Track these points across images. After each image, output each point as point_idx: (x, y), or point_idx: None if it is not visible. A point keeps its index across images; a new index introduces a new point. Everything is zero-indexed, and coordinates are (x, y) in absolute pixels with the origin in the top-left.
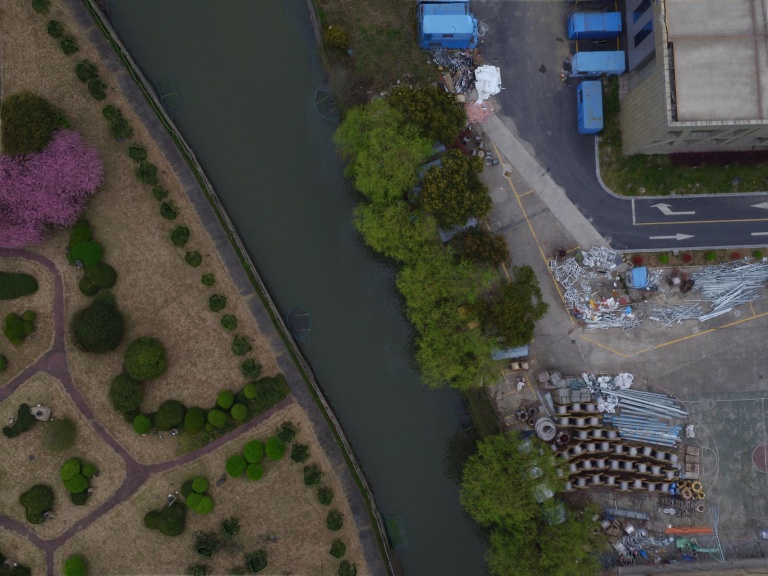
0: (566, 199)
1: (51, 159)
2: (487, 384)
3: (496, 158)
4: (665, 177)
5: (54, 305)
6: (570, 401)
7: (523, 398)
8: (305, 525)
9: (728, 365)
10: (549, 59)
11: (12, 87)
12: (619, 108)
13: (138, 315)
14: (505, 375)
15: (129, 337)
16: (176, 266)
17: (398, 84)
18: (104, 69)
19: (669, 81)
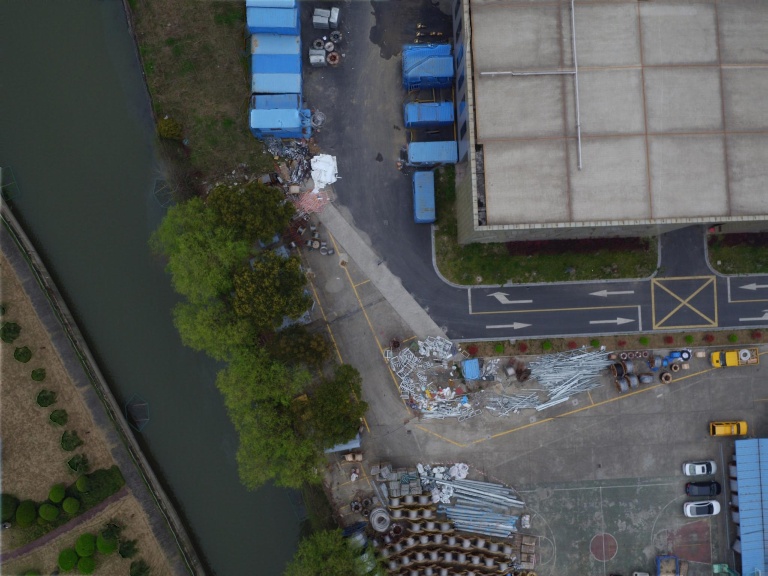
0: (402, 289)
1: None
2: (322, 475)
3: (332, 248)
4: (502, 266)
5: None
6: (400, 494)
7: (358, 488)
8: None
9: (566, 454)
10: (386, 147)
11: None
12: (455, 197)
13: None
14: (340, 465)
15: None
16: (11, 359)
17: (233, 174)
18: None
19: (476, 186)
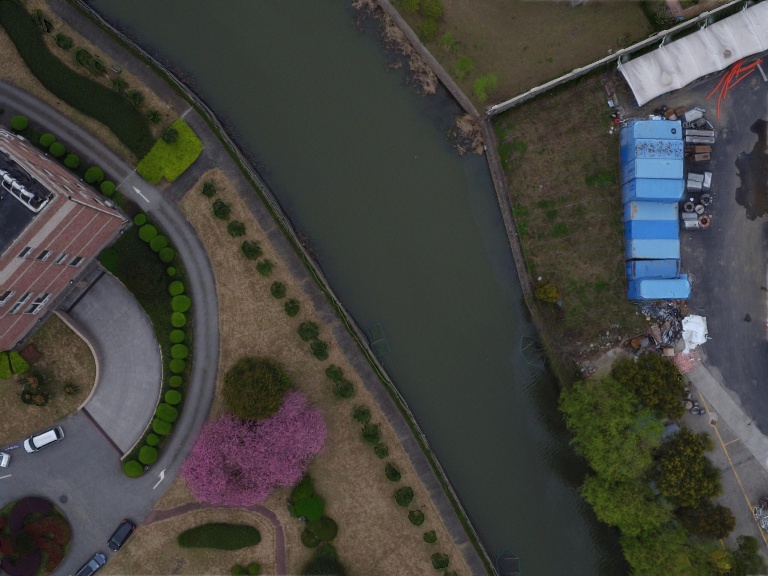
0: None
1: (282, 426)
2: None
3: (703, 407)
4: None
5: (276, 556)
6: None
7: None
8: None
9: None
10: (754, 308)
11: (231, 339)
12: None
13: (358, 566)
14: None
15: None
16: (394, 517)
17: (608, 336)
18: (320, 322)
19: None
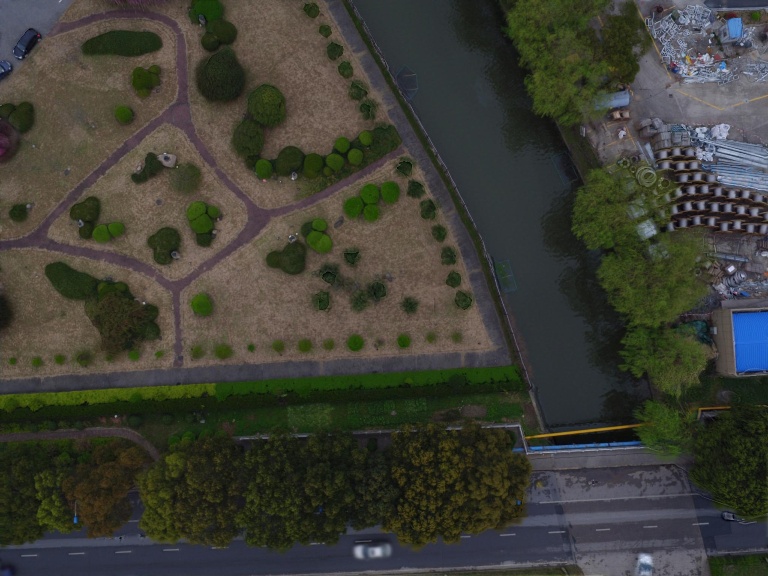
0: None
1: None
2: (589, 135)
3: None
4: None
5: (177, 61)
6: (672, 143)
7: (624, 148)
8: (418, 266)
9: None
10: None
11: None
12: None
13: (257, 69)
14: (606, 127)
15: (249, 89)
16: (292, 24)
17: None
18: None
19: None
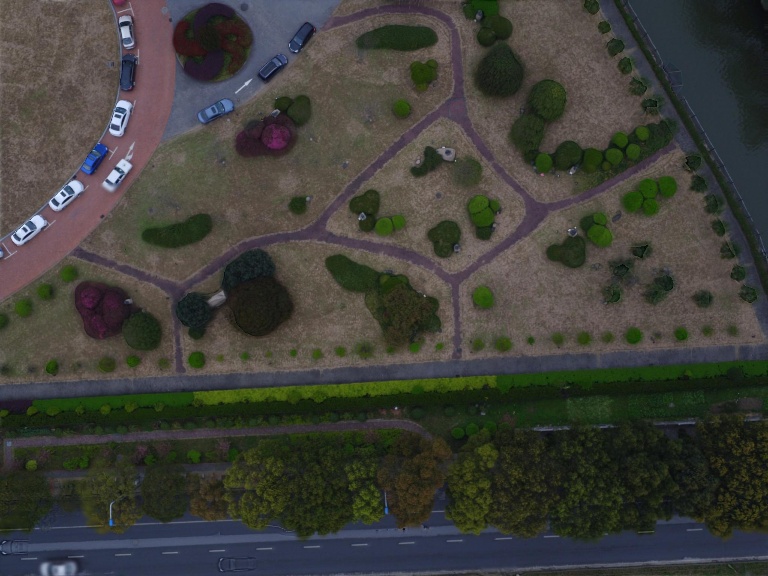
0: None
1: None
2: None
3: None
4: None
5: (453, 56)
6: None
7: None
8: (694, 260)
9: None
10: None
11: None
12: None
13: (532, 64)
14: None
15: (525, 84)
16: (565, 20)
17: None
18: None
19: None
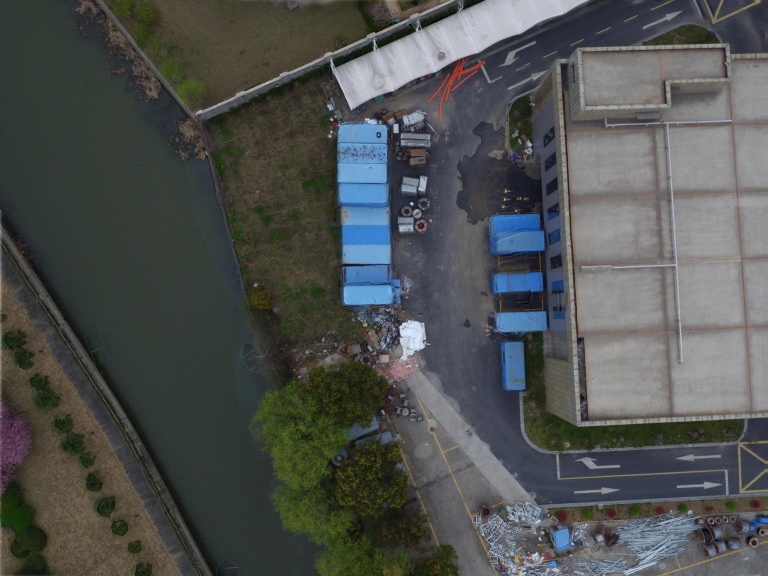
0: (491, 455)
1: None
2: None
3: (421, 414)
4: None
5: None
6: None
7: None
8: None
9: None
10: (474, 313)
11: None
12: (543, 365)
13: None
14: None
15: None
16: (105, 527)
17: (323, 342)
18: (33, 331)
19: (579, 382)
